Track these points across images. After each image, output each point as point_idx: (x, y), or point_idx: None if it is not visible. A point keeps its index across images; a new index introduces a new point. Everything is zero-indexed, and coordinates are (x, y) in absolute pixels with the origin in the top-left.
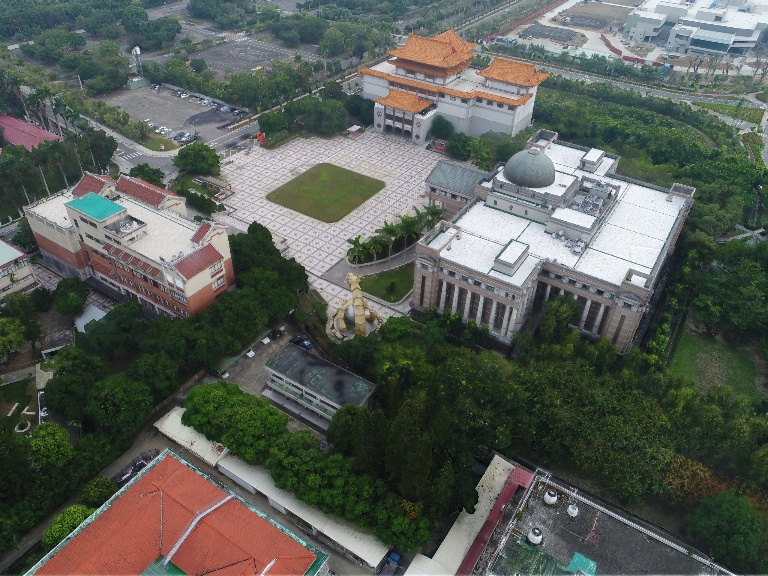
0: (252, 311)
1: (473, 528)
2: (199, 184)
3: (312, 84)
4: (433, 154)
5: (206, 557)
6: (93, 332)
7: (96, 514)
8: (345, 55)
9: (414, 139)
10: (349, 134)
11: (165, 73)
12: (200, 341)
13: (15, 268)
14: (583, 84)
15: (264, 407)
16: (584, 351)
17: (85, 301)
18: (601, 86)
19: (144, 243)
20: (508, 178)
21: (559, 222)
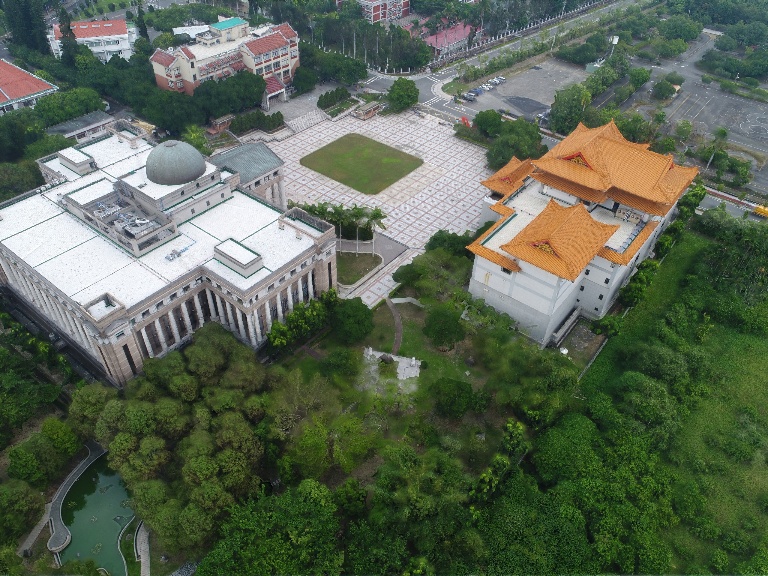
0: (140, 97)
1: None
2: None
3: None
4: None
5: None
6: None
7: (36, 77)
8: None
9: None
10: None
11: None
12: None
13: None
14: None
15: (56, 103)
16: None
17: None
18: None
19: (199, 47)
20: None
21: None
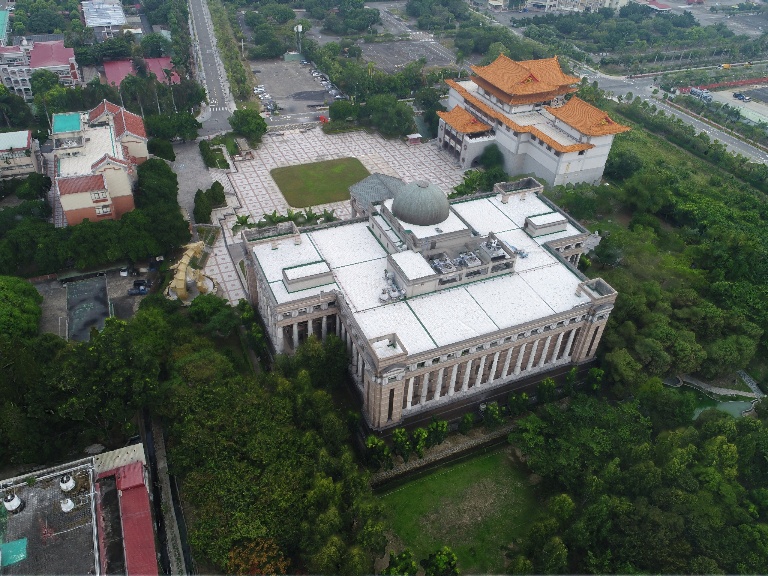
0: (100, 240)
1: None
2: None
3: (437, 90)
4: None
5: None
6: None
7: None
8: None
9: (461, 161)
10: (408, 140)
11: (313, 52)
12: (39, 245)
13: (19, 155)
14: (744, 162)
15: None
16: None
17: (35, 193)
18: (756, 168)
19: (73, 160)
20: None
21: (392, 263)
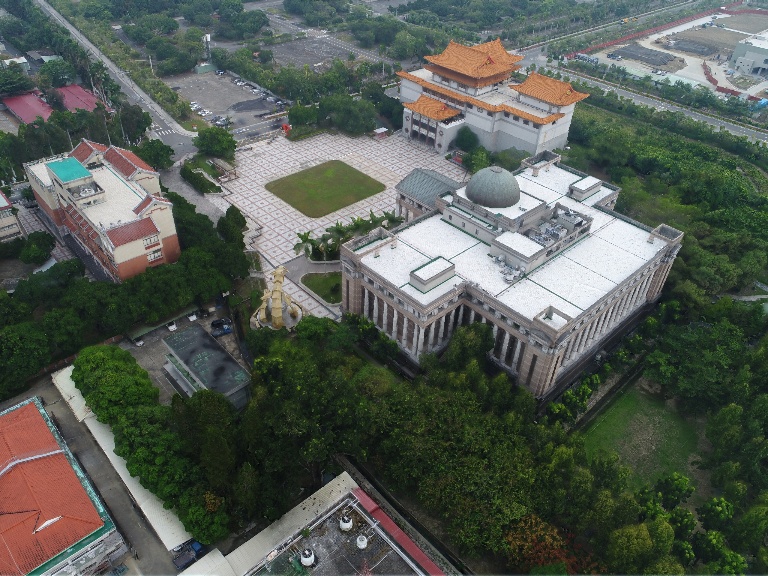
0: (172, 286)
1: (283, 537)
2: None
3: None
4: (450, 165)
5: (6, 500)
6: (31, 282)
7: None
8: (414, 59)
9: (437, 147)
10: (375, 135)
11: (229, 61)
12: (111, 305)
13: (0, 216)
14: (652, 111)
15: None
16: None
17: (45, 254)
18: (669, 115)
19: (98, 208)
20: (467, 194)
21: (500, 246)
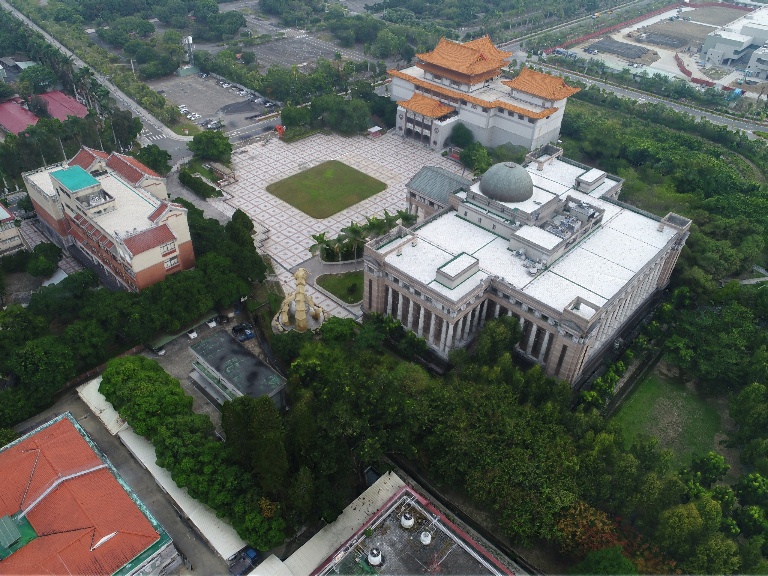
0: (194, 293)
1: (338, 539)
2: (208, 169)
3: (352, 83)
4: (447, 161)
5: (56, 518)
6: (45, 295)
7: None
8: (396, 58)
9: (432, 145)
10: (369, 134)
11: (212, 63)
12: (133, 315)
13: (2, 228)
14: (635, 103)
15: (168, 386)
16: (513, 377)
17: (54, 266)
18: (651, 107)
19: (109, 217)
20: (481, 189)
21: (521, 240)
